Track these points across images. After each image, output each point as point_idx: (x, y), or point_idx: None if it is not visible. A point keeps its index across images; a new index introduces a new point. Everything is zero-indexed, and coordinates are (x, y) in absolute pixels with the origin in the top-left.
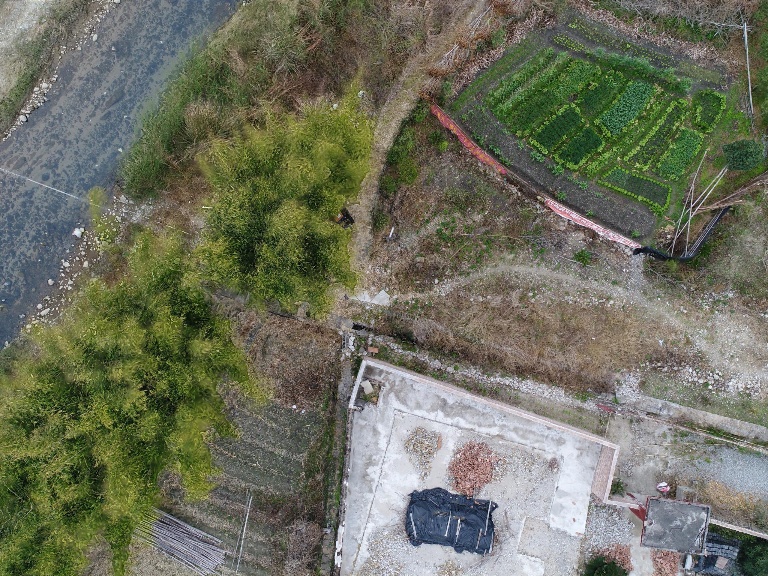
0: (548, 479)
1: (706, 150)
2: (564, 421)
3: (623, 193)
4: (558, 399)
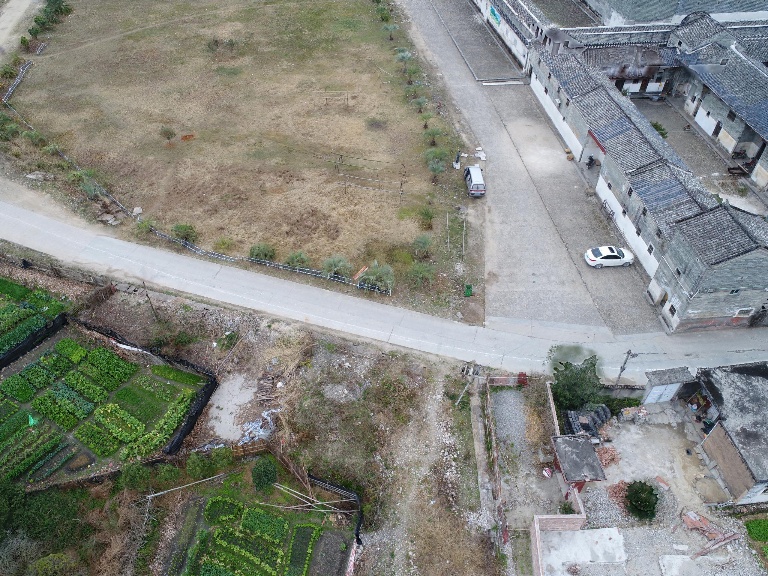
0: (588, 572)
1: (258, 504)
2: (531, 571)
3: (307, 568)
4: None
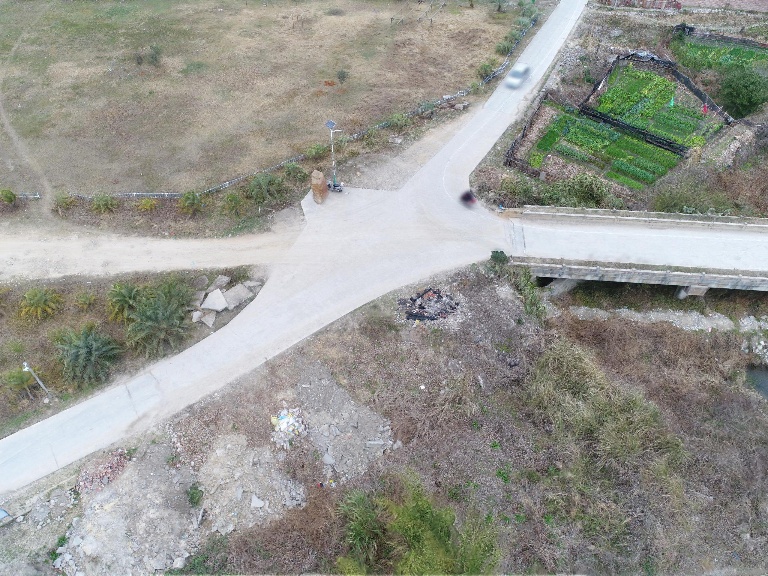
0: None
1: None
2: (689, 6)
3: None
4: (695, 9)
